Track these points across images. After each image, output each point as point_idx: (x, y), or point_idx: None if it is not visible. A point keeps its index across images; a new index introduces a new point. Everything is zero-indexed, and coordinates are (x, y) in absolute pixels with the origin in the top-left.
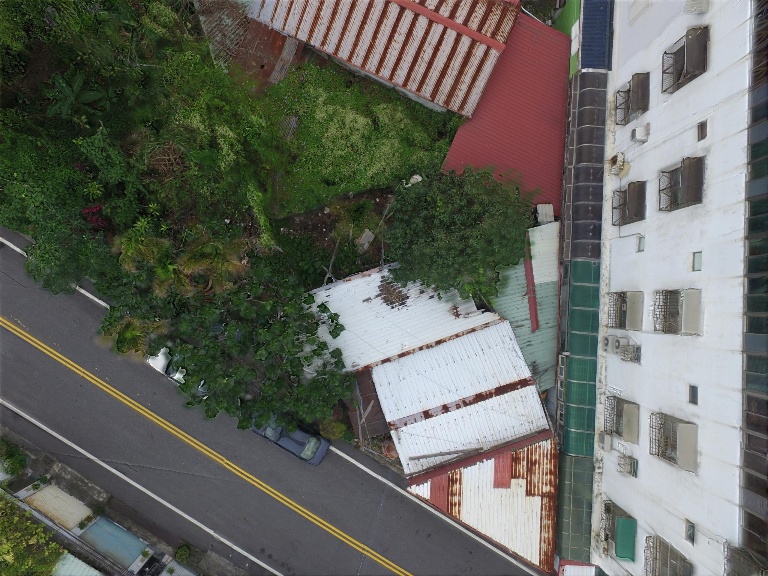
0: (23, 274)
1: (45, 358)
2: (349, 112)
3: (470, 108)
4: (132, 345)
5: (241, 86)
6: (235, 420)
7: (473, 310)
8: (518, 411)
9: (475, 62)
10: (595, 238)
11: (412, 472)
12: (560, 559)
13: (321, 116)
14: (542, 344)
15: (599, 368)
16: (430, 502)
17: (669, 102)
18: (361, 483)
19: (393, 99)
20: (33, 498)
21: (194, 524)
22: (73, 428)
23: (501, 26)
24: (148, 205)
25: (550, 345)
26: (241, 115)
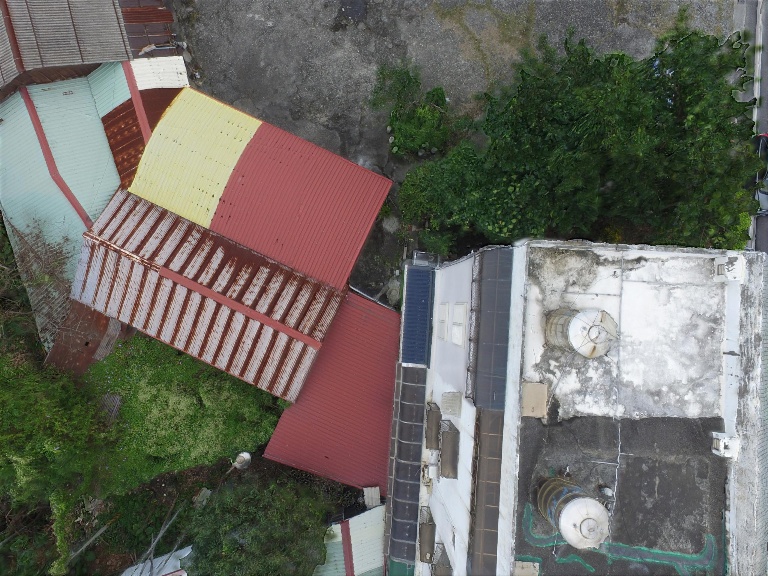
0: None
1: None
2: (173, 392)
3: (293, 394)
4: None
5: (64, 364)
6: None
7: None
8: None
9: (294, 355)
10: (411, 539)
11: None
12: None
13: (144, 397)
14: None
15: None
16: None
17: None
18: None
19: None
20: None
21: None
22: None
23: (322, 317)
24: None
25: None
26: (37, 436)
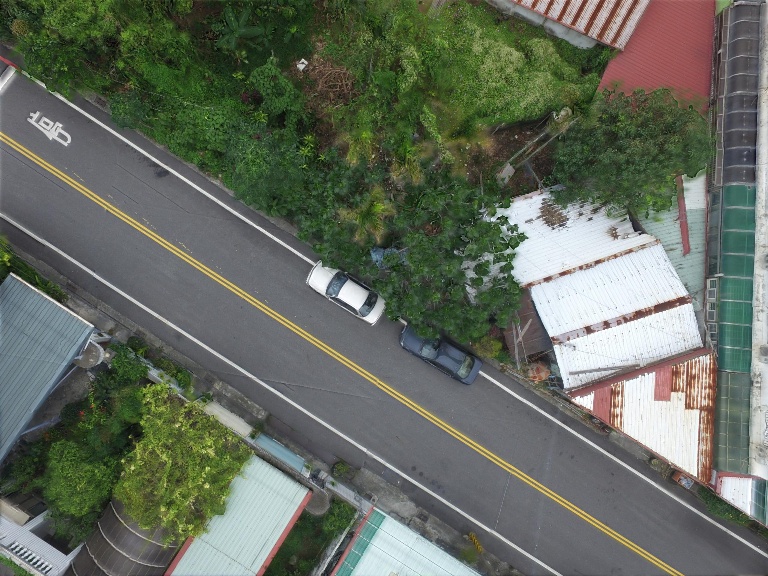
0: (187, 201)
1: (208, 280)
2: (504, 46)
3: (623, 41)
4: (371, 228)
5: None
6: (387, 343)
7: (631, 231)
8: (675, 329)
9: None
10: (749, 163)
11: (571, 387)
12: (717, 471)
13: (478, 49)
14: (692, 268)
15: (756, 287)
16: (593, 413)
17: None
18: (507, 406)
19: (539, 36)
20: (205, 409)
21: (348, 442)
22: (234, 348)
23: None
24: (303, 137)
25: (699, 269)
26: (422, 38)
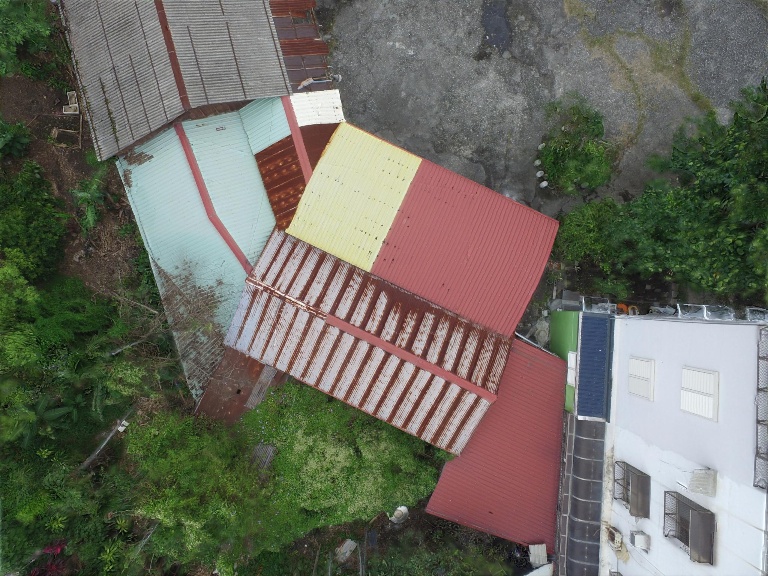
0: None
1: None
2: (330, 443)
3: (459, 447)
4: None
5: (215, 413)
6: None
7: None
8: None
9: (464, 407)
10: None
11: None
12: None
13: (300, 449)
14: None
15: None
16: None
17: (671, 542)
18: None
19: None
20: None
21: None
22: None
23: (493, 367)
24: (116, 521)
25: None
26: (210, 497)
